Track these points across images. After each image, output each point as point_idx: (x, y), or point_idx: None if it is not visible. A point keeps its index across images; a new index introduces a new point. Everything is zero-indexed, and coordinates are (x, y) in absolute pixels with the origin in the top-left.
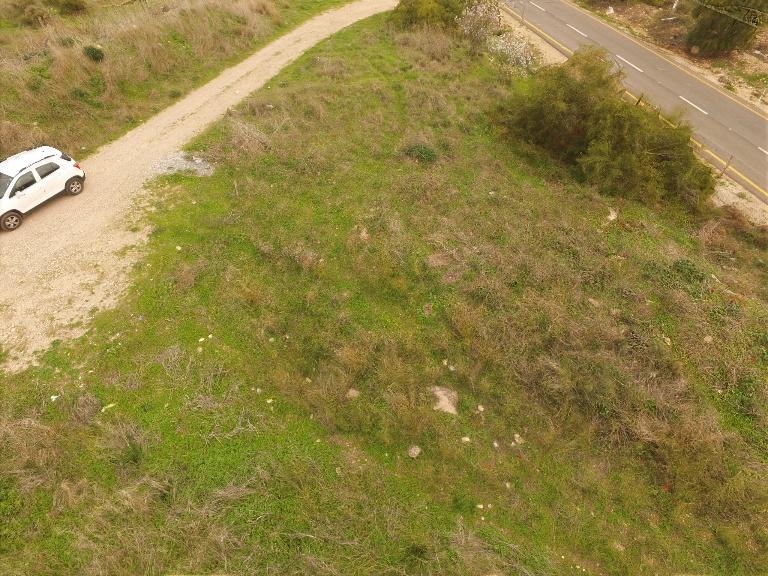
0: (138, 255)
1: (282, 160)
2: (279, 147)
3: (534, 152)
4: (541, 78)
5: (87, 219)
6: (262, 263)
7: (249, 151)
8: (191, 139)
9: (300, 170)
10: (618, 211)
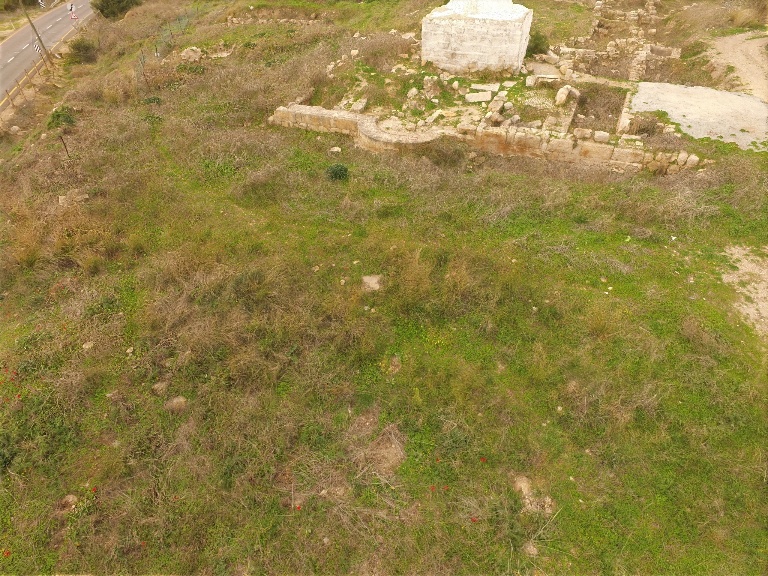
0: None
1: None
2: None
3: None
4: None
5: None
6: (636, 388)
7: None
8: None
9: None
10: None
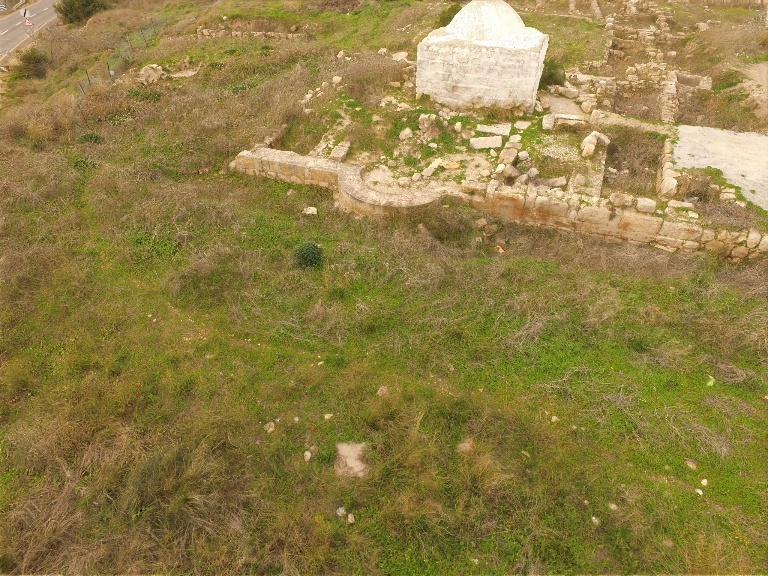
0: None
1: None
2: None
3: None
4: None
5: None
6: None
7: None
8: None
9: None
10: None
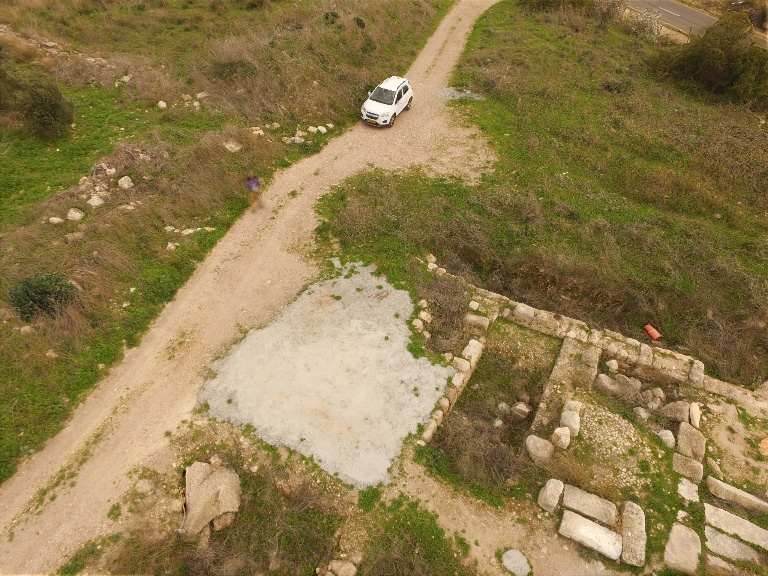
0: (484, 138)
1: (527, 91)
2: (518, 84)
3: (694, 86)
4: (657, 45)
5: (430, 122)
6: (565, 142)
7: (507, 84)
8: (449, 80)
9: (546, 95)
10: (765, 118)
